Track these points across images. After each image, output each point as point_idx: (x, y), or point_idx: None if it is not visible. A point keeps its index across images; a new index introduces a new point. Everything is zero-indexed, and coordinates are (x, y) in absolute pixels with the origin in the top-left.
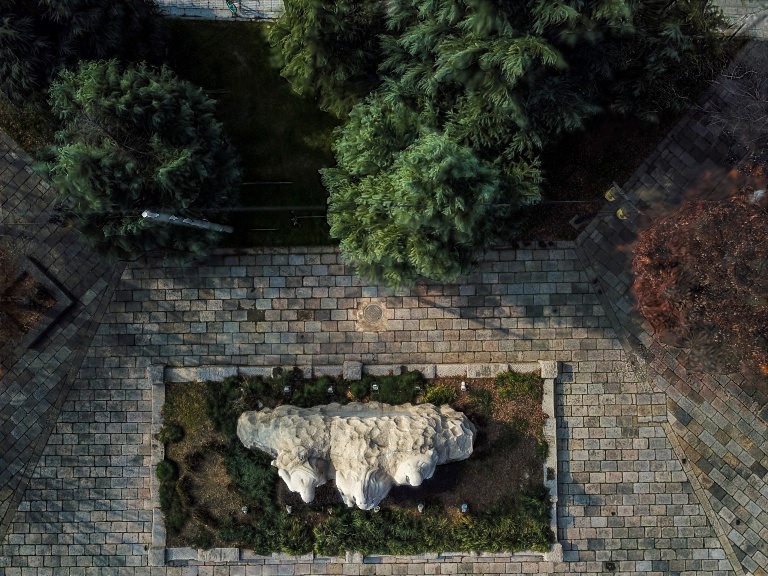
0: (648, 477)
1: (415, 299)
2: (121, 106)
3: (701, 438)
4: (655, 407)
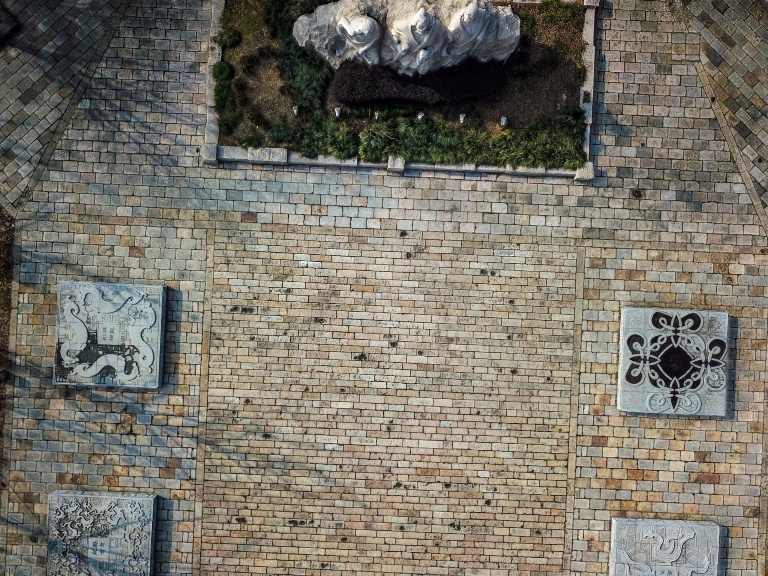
0: (678, 112)
1: None
2: None
3: (730, 79)
4: (689, 46)
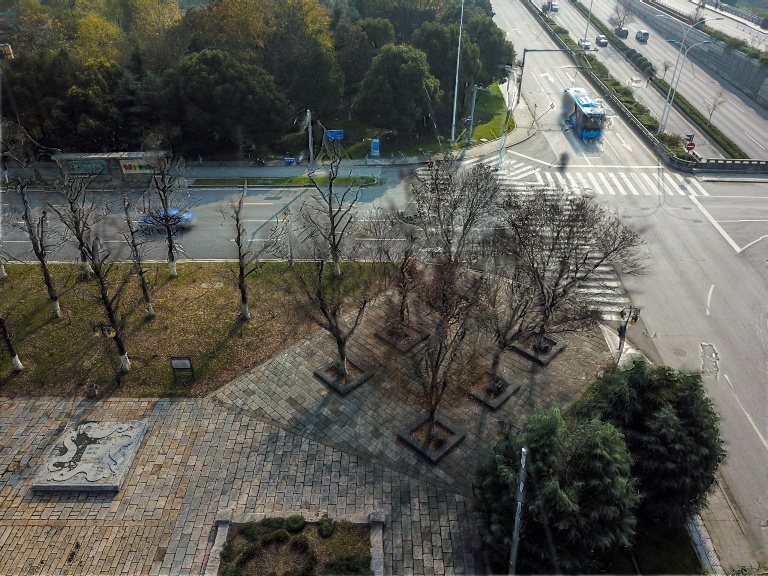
0: None
1: None
2: (599, 452)
3: None
4: None
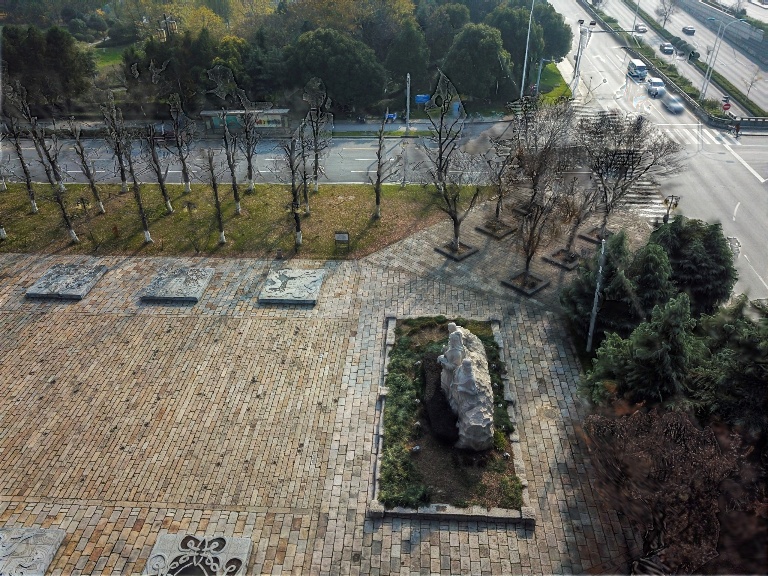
0: None
1: (566, 437)
2: (651, 254)
3: None
4: None
